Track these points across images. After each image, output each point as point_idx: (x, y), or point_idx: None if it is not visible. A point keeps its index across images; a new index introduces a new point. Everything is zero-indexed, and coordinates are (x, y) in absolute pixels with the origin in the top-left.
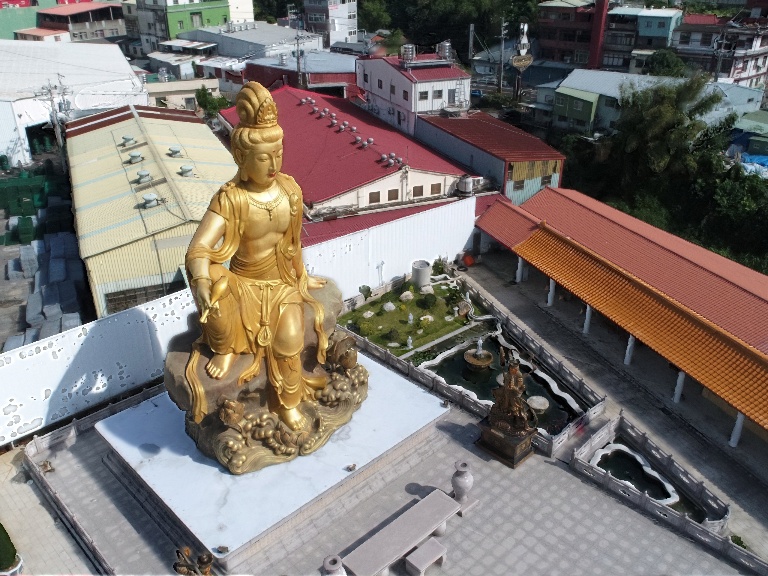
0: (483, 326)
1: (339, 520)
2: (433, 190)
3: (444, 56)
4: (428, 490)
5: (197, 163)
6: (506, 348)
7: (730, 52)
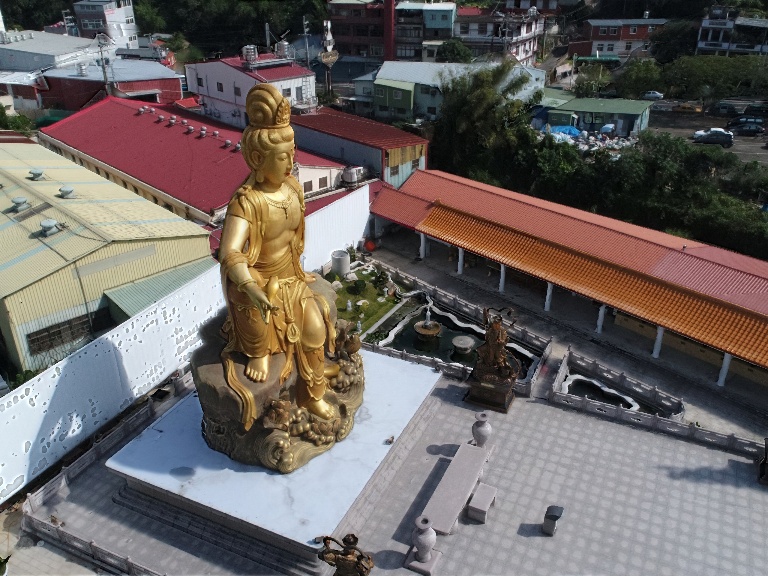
0: (413, 301)
1: (386, 493)
2: (321, 184)
3: (284, 55)
4: (447, 448)
5: (66, 184)
6: (443, 316)
7: (512, 39)
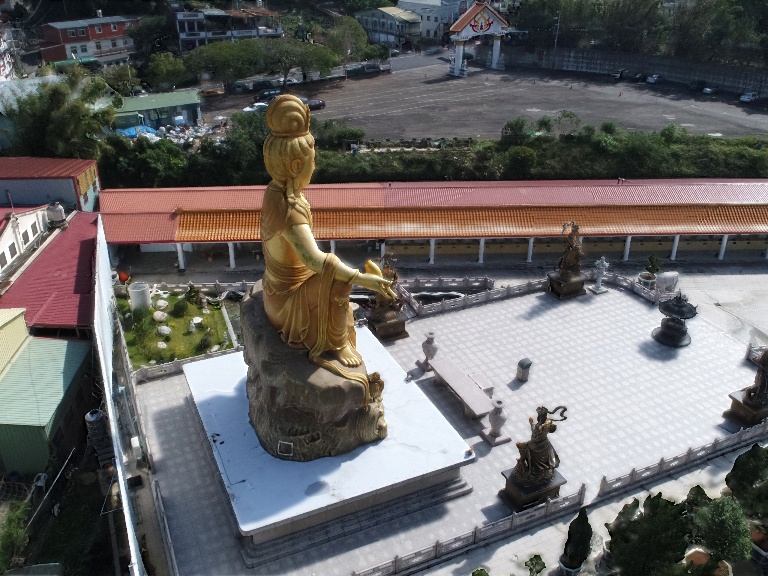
0: (228, 303)
1: None
2: (33, 231)
3: None
4: None
5: None
6: None
7: None
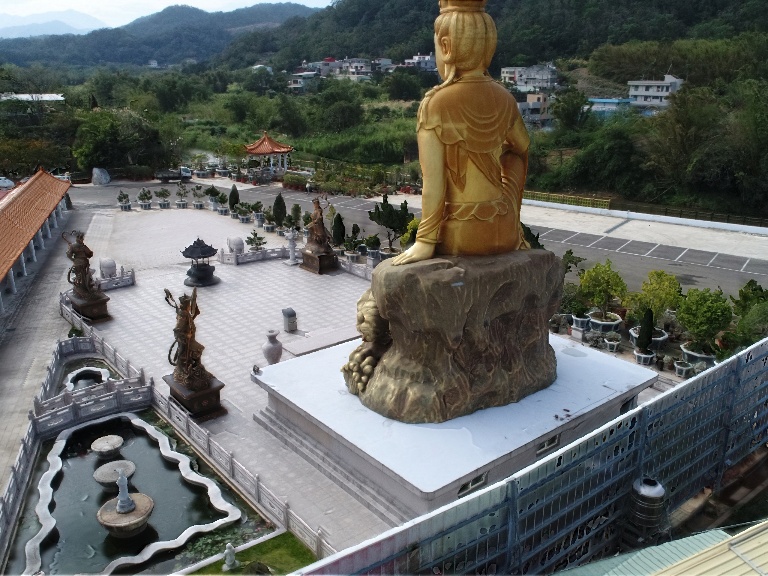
0: None
1: None
2: None
3: None
4: None
5: None
6: None
7: None
